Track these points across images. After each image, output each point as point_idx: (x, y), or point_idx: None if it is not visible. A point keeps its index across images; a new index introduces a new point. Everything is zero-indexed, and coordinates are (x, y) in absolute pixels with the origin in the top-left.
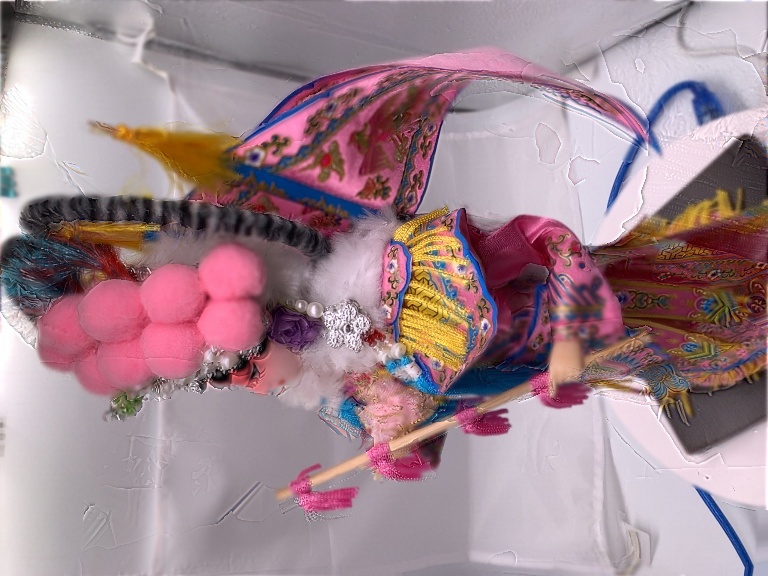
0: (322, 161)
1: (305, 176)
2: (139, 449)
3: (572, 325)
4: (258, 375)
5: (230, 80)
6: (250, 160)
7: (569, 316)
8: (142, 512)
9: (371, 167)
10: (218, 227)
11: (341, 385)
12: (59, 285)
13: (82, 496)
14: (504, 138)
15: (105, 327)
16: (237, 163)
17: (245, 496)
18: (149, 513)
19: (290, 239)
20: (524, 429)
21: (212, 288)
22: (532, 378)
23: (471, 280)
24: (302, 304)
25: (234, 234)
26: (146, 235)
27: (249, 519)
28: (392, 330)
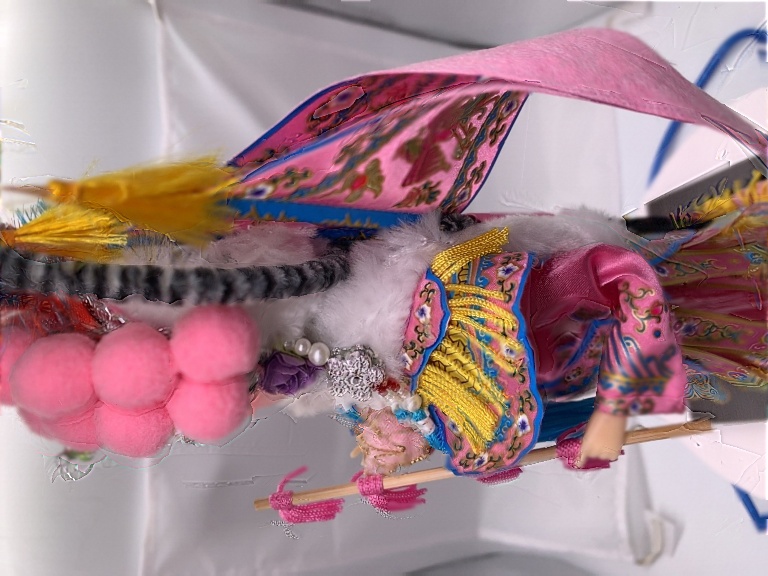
0: (354, 183)
1: (328, 198)
2: None
3: (623, 400)
4: None
5: None
6: (252, 194)
7: (623, 387)
8: None
9: (419, 175)
10: (198, 300)
11: None
12: None
13: None
14: (586, 4)
15: (43, 421)
16: (232, 203)
17: None
18: None
19: (297, 293)
20: None
21: (186, 374)
22: (559, 445)
23: (519, 366)
24: (304, 347)
25: (220, 303)
26: (107, 249)
27: None
28: (409, 382)
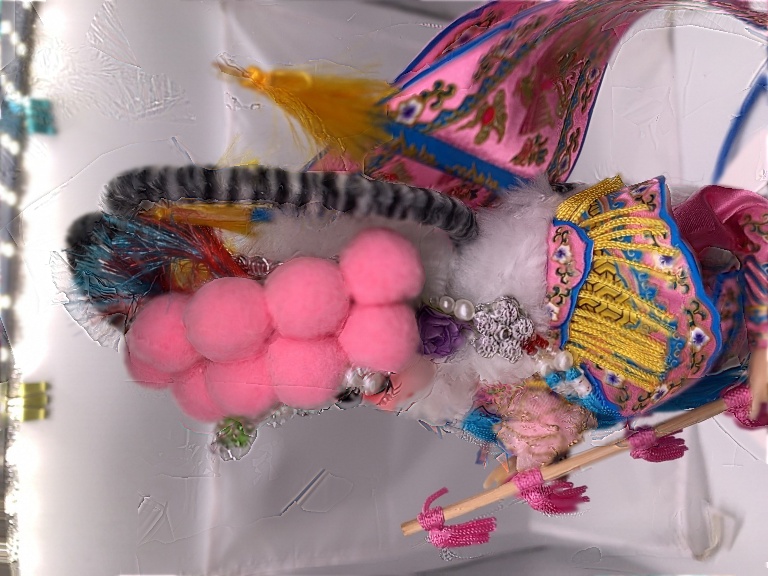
0: (484, 116)
1: (461, 136)
2: (197, 436)
3: None
4: (390, 391)
5: (286, 18)
6: (403, 115)
7: None
8: (201, 503)
9: (532, 124)
10: (370, 208)
11: (473, 394)
12: (144, 277)
13: (137, 487)
14: None
15: (226, 346)
16: (389, 119)
17: (309, 485)
18: (208, 504)
19: (448, 221)
20: None
21: (361, 291)
22: (726, 395)
23: (679, 277)
24: (448, 302)
25: (387, 217)
26: (255, 213)
27: (314, 510)
28: (557, 335)
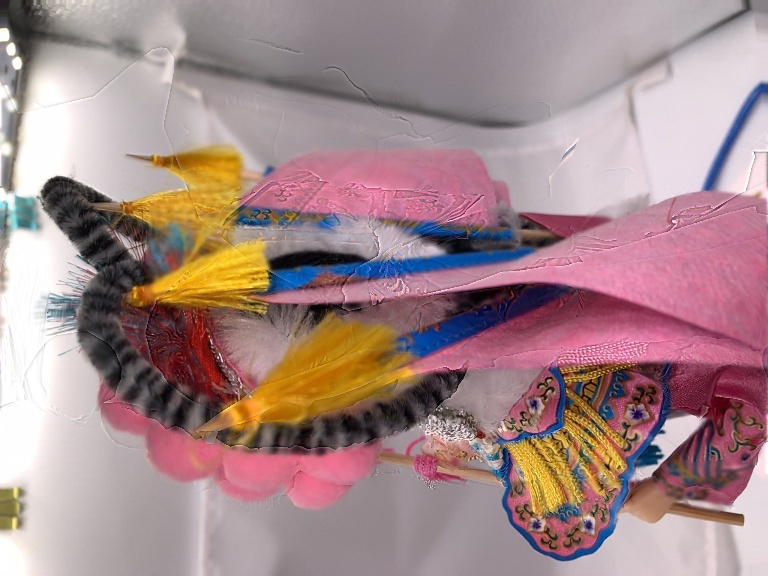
0: None
1: None
2: None
3: (682, 488)
4: None
5: None
6: None
7: (687, 478)
8: None
9: None
10: None
11: None
12: None
13: None
14: None
15: None
16: None
17: None
18: None
19: None
20: (592, 199)
21: None
22: None
23: None
24: None
25: None
26: (246, 314)
27: None
28: (495, 437)
